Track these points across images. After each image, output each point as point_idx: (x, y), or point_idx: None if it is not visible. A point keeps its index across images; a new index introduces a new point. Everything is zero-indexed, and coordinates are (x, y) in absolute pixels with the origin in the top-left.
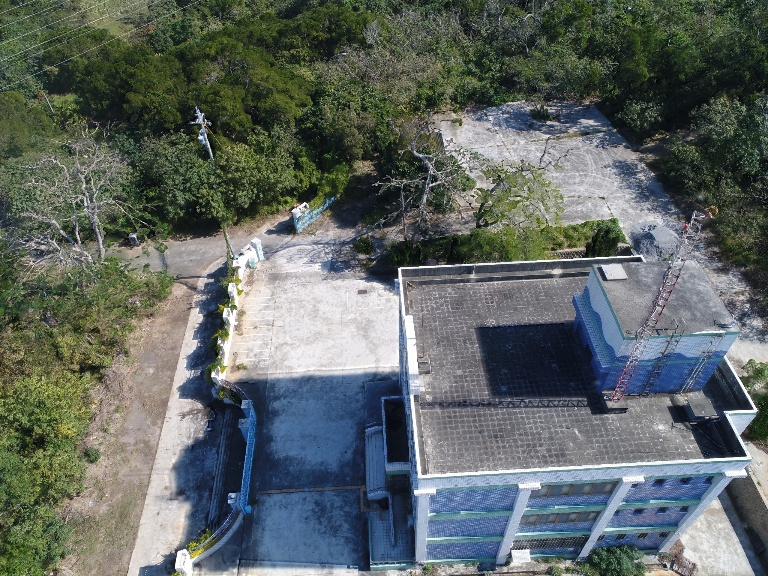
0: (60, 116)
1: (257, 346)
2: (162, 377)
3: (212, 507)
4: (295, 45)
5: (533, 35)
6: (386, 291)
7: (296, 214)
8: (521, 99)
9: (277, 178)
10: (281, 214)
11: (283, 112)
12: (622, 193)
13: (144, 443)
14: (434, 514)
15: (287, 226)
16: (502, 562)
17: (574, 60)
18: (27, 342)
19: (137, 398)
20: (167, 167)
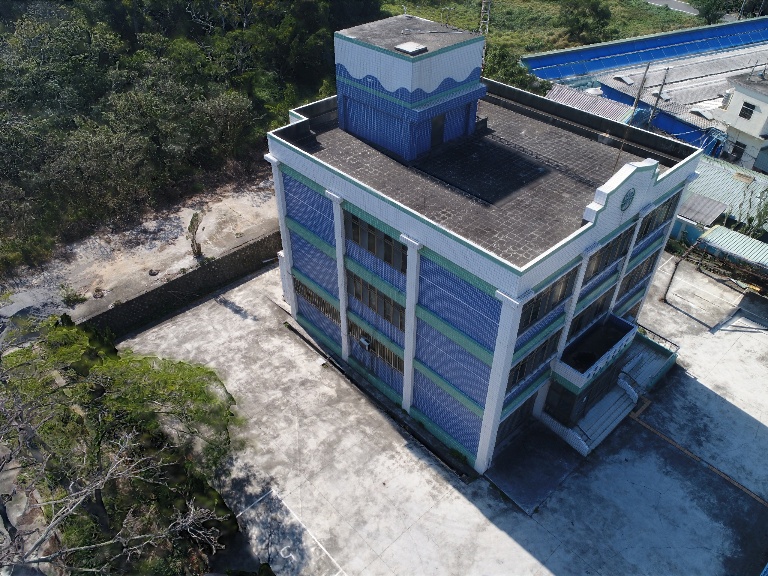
0: None
1: None
2: None
3: None
4: None
5: None
6: None
7: None
8: None
9: None
10: None
11: None
12: None
13: None
14: None
15: None
16: None
17: None
18: None
19: None
20: None
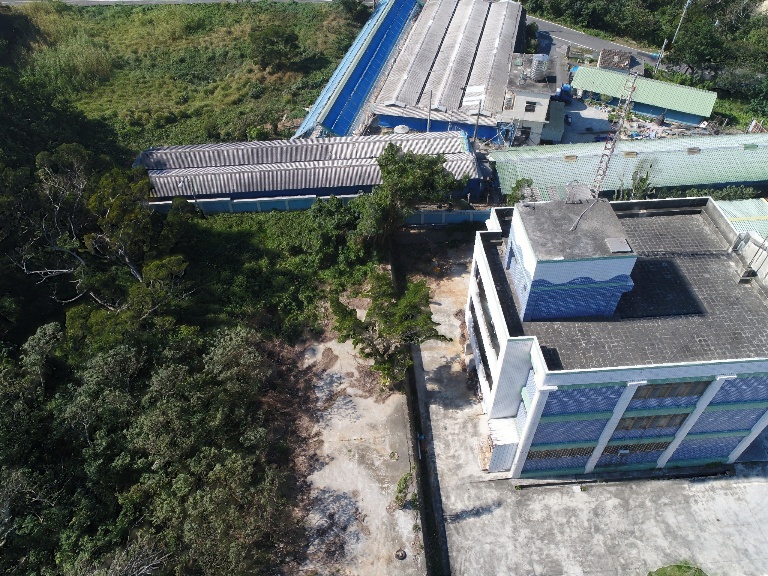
0: None
1: None
2: None
3: None
4: None
5: None
6: None
7: None
8: None
9: None
10: None
11: None
12: None
13: None
14: None
15: None
16: None
17: None
18: None
19: None
20: None
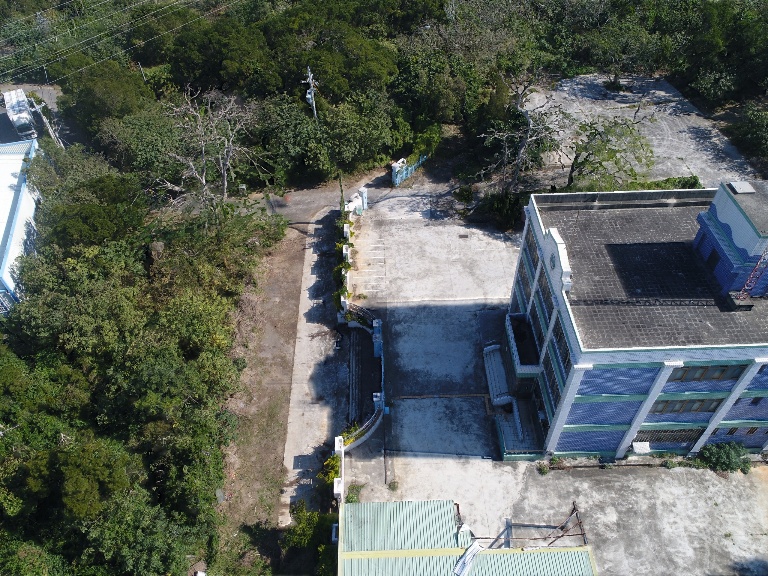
0: (153, 84)
1: (373, 280)
2: (288, 305)
3: (351, 410)
4: (374, 21)
5: (602, 13)
6: (485, 236)
7: (396, 168)
8: (593, 72)
9: (379, 134)
10: (377, 170)
11: (375, 78)
12: (699, 154)
13: (281, 358)
14: (579, 396)
15: (384, 181)
16: (621, 456)
17: (646, 35)
18: (173, 268)
19: (268, 322)
20: (280, 122)
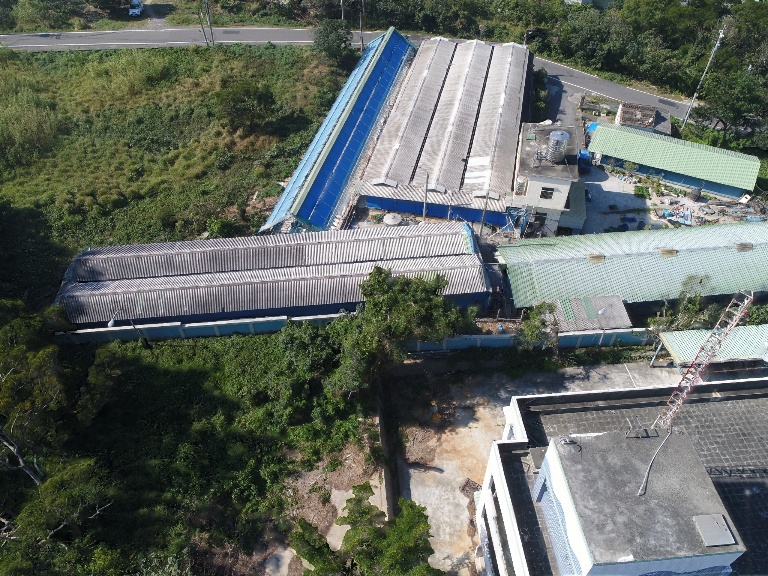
0: None
1: None
2: None
3: None
4: None
5: None
6: None
7: None
8: None
9: None
10: None
11: None
12: None
13: None
14: None
15: None
16: None
17: None
18: None
19: None
20: None
